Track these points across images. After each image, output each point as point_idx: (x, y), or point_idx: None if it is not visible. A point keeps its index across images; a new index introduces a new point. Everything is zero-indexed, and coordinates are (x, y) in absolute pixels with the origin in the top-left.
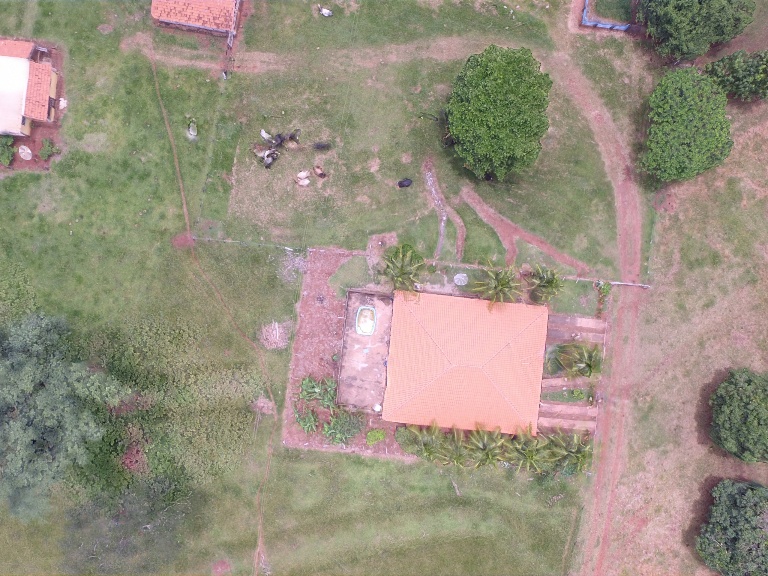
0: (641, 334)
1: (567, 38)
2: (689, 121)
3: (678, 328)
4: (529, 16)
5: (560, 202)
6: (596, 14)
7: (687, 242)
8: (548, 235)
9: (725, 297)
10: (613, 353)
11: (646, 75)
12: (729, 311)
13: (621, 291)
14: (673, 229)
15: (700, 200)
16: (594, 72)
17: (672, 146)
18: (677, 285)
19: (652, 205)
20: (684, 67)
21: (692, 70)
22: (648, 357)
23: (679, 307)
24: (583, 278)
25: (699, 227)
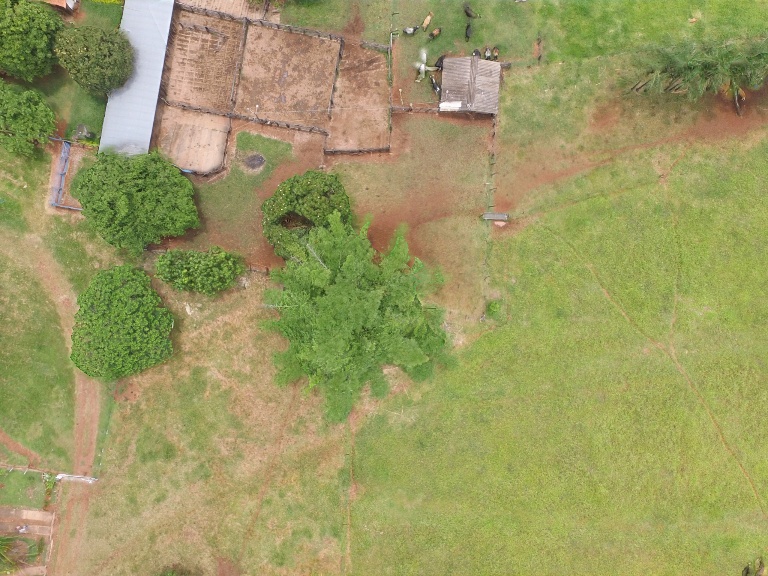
0: (89, 528)
1: (43, 219)
2: (104, 325)
3: (127, 522)
4: (4, 196)
5: (20, 388)
6: (72, 196)
7: (144, 433)
8: (3, 423)
9: (177, 492)
10: (59, 547)
11: (116, 260)
12: (182, 506)
13: (71, 483)
14: (133, 419)
15: (164, 389)
16: (65, 255)
17: (85, 351)
18: (129, 478)
19: (112, 394)
20: (157, 252)
21: (124, 269)
22: (95, 551)
23: (130, 501)
24: (32, 469)
25: (160, 417)
